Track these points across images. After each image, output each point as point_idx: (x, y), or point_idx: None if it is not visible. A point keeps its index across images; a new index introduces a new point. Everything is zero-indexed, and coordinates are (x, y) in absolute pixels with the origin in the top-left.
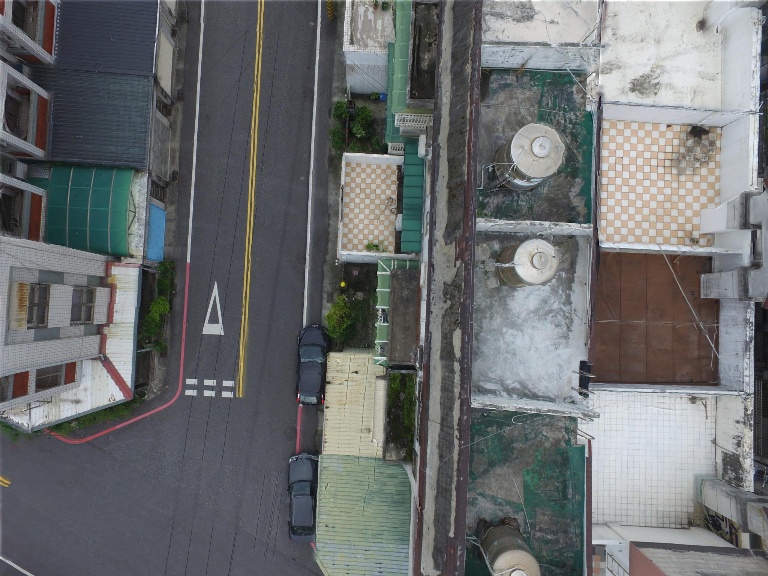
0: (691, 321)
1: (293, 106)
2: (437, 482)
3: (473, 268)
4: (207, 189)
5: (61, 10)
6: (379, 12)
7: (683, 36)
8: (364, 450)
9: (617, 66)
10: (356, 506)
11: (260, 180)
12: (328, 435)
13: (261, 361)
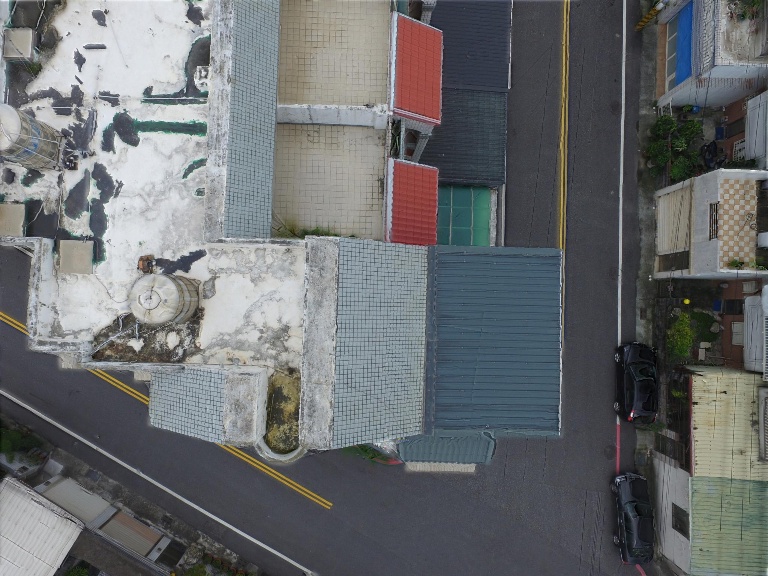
0: None
1: (601, 119)
2: None
3: None
4: (517, 205)
5: None
6: (732, 24)
7: None
8: (736, 472)
9: None
10: None
11: (571, 195)
12: (699, 457)
13: (578, 379)
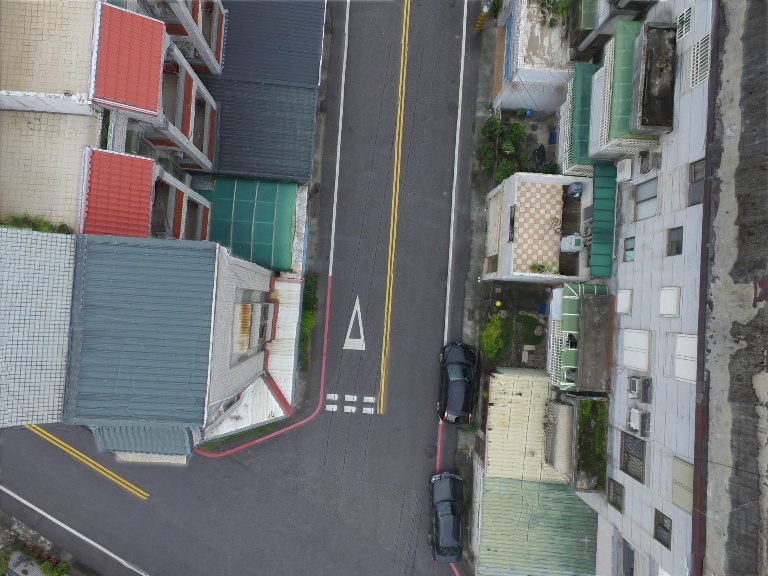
0: None
1: (437, 120)
2: (729, 527)
3: None
4: (349, 202)
5: (229, 20)
6: (546, 29)
7: None
8: (527, 474)
9: None
10: (505, 528)
11: (403, 194)
12: (491, 457)
13: (402, 378)
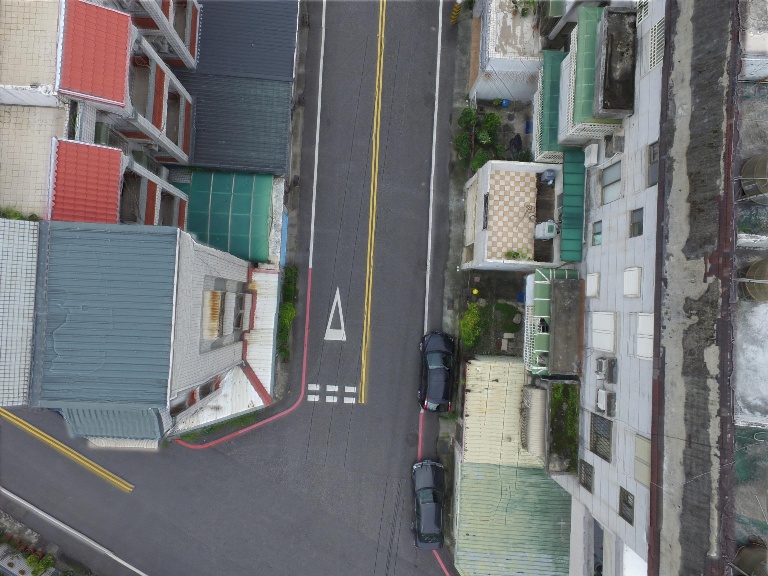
0: None
1: (414, 111)
2: (683, 499)
3: None
4: (328, 194)
5: (203, 15)
6: (518, 18)
7: None
8: (505, 459)
9: None
10: (486, 514)
11: (382, 185)
12: (469, 443)
13: (383, 367)
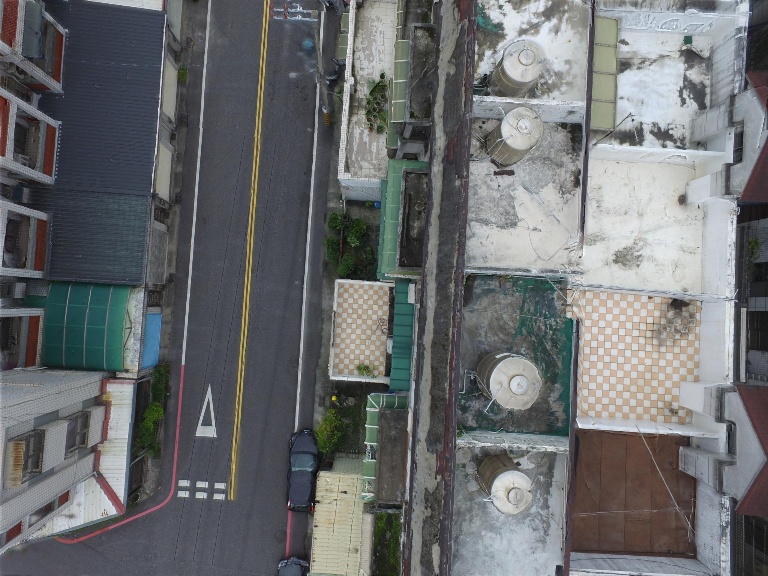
0: (667, 506)
1: (289, 211)
2: None
3: (453, 479)
4: (203, 292)
5: (62, 131)
6: (374, 135)
7: (666, 209)
8: (351, 570)
9: (601, 238)
10: None
11: (255, 284)
12: (316, 554)
13: (253, 464)
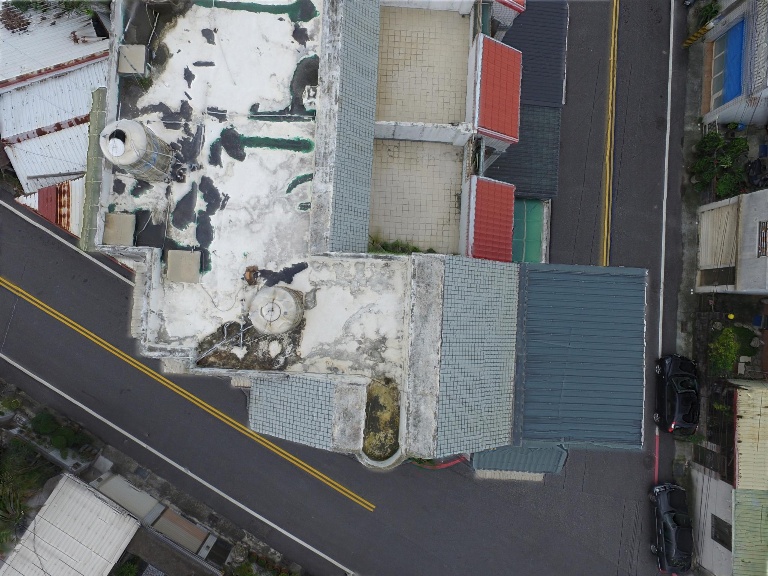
0: None
1: (647, 135)
2: None
3: None
4: (562, 217)
5: None
6: None
7: None
8: None
9: None
10: None
11: (616, 208)
12: (743, 470)
13: None
